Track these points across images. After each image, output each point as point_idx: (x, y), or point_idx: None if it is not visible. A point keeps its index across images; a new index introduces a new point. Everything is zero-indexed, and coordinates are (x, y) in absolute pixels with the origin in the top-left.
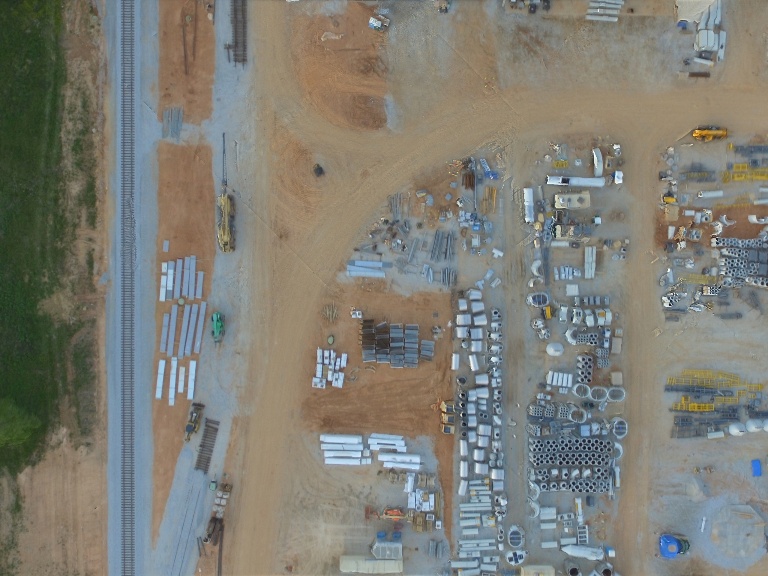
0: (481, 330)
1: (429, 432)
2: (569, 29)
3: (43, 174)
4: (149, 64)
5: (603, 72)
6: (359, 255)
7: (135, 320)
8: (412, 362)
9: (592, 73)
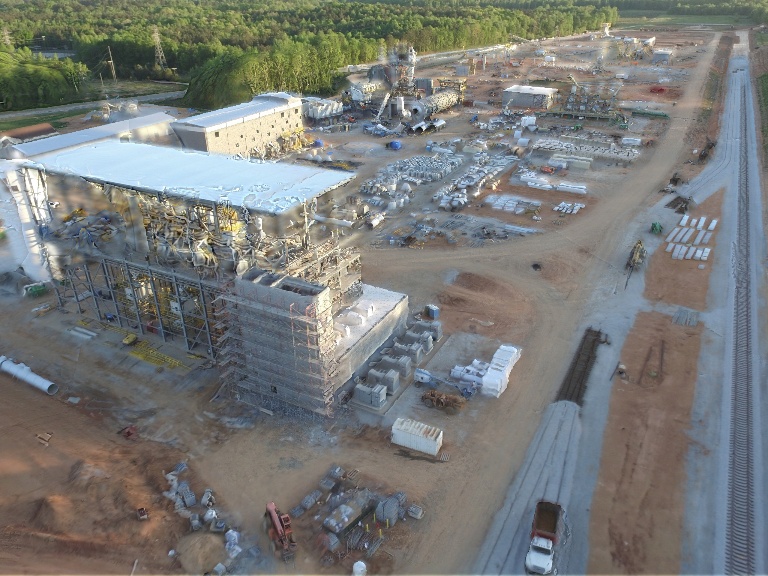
0: None
1: (509, 186)
2: None
3: None
4: (713, 357)
5: None
6: None
7: None
8: (507, 198)
9: None
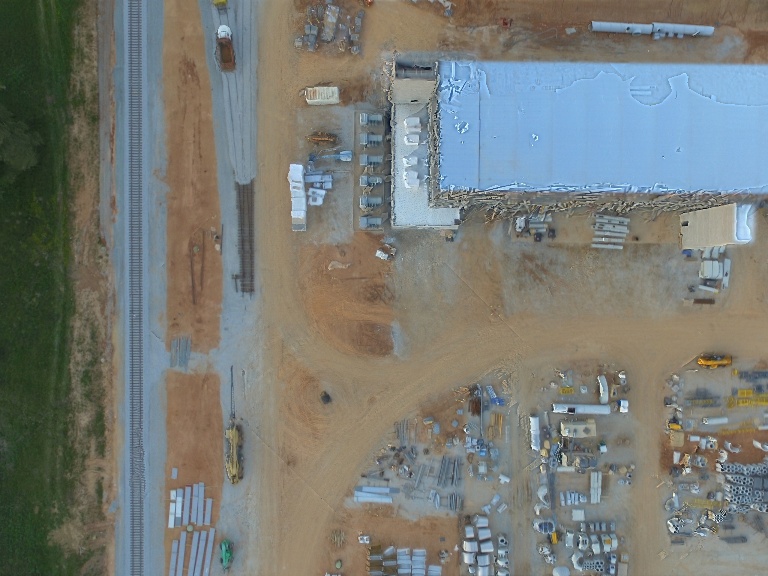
0: (488, 556)
1: None
2: (574, 257)
3: (52, 406)
4: (157, 294)
5: (608, 299)
6: (366, 481)
7: (144, 547)
8: None
9: (597, 300)
